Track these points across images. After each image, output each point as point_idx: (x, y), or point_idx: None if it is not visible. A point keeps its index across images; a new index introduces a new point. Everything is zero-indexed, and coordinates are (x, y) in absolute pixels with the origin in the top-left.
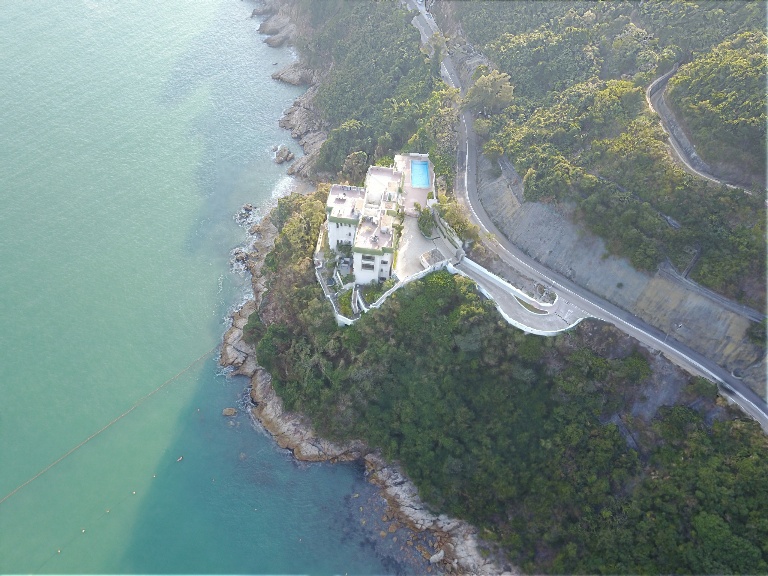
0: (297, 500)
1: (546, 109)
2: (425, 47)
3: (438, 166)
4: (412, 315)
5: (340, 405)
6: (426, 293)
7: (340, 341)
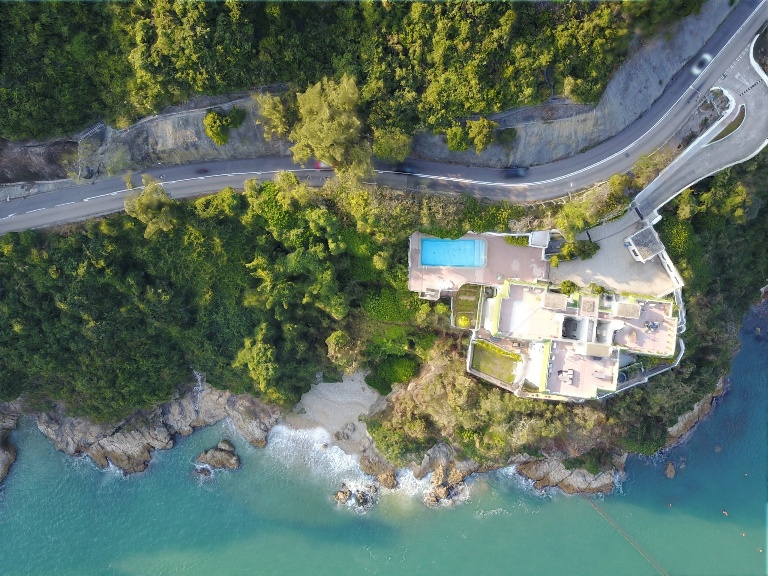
0: (760, 388)
1: (403, 28)
2: (150, 229)
3: (485, 226)
4: (704, 275)
5: (733, 355)
6: (689, 257)
7: (684, 360)
